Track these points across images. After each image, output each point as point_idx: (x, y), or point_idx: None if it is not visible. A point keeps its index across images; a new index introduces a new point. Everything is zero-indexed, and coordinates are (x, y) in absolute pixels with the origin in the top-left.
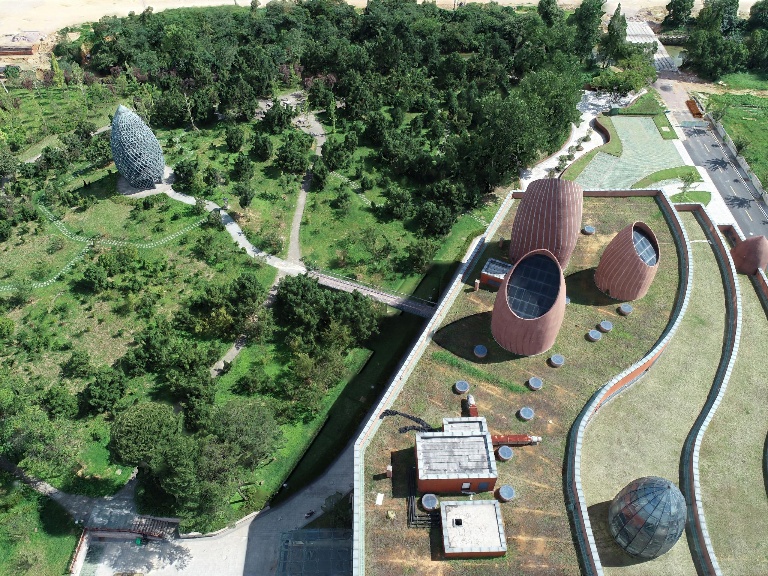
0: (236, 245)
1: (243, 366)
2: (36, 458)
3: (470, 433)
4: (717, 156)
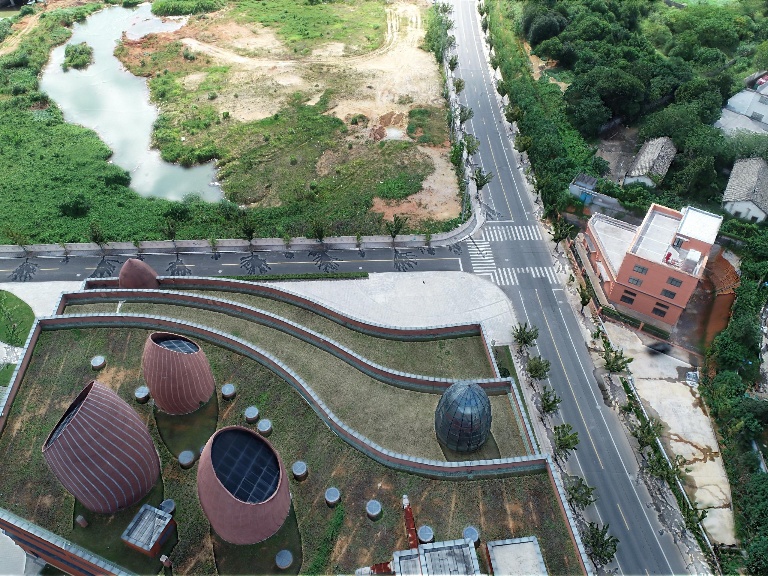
0: None
1: None
2: None
3: (424, 568)
4: None
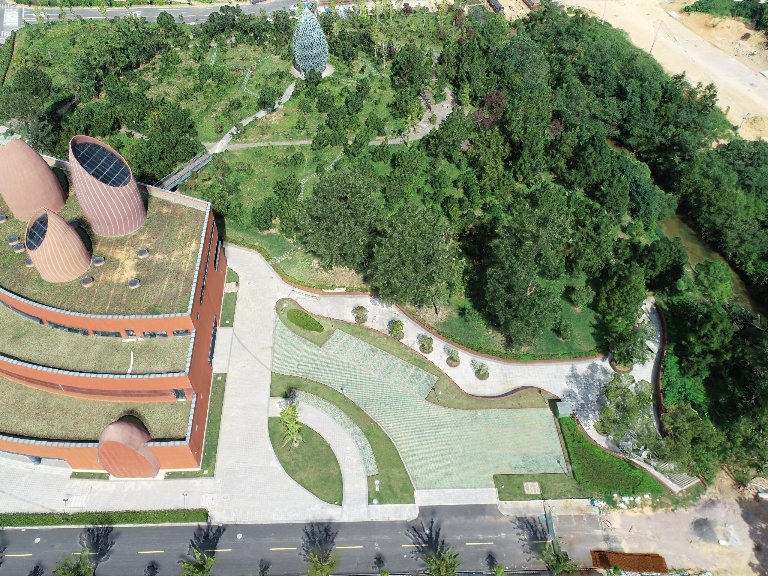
0: (241, 119)
1: (133, 143)
2: (56, 72)
3: None
4: (454, 553)
